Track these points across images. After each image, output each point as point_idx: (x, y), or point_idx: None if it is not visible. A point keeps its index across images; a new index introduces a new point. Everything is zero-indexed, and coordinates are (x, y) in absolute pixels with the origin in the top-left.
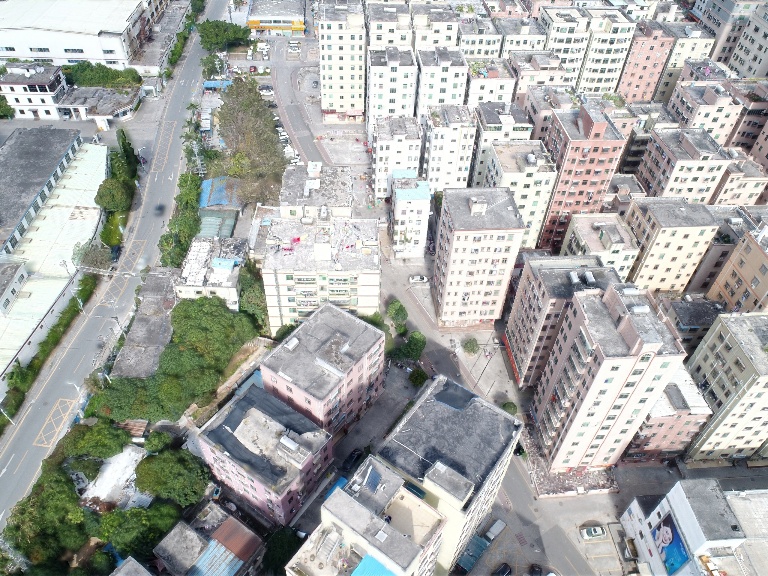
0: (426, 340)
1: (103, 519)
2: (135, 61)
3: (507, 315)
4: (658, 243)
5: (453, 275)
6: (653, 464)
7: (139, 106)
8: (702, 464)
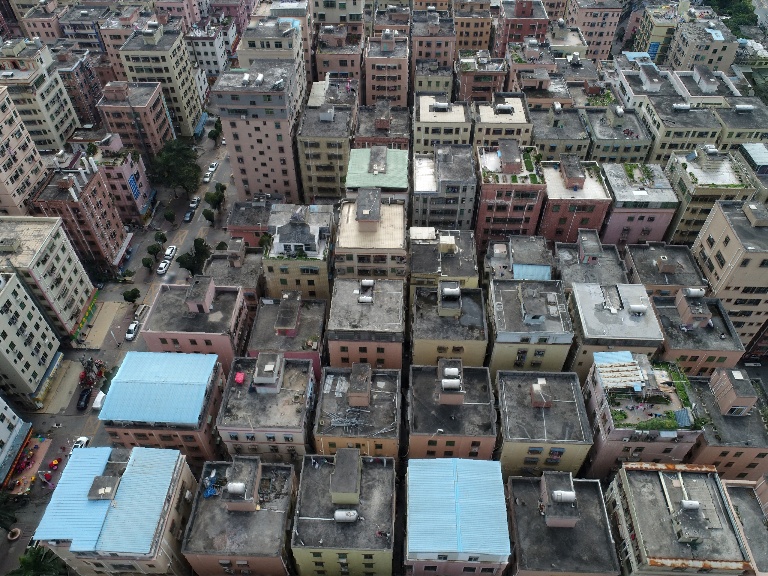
0: None
1: (718, 8)
2: None
3: None
4: None
5: None
6: None
7: None
8: None
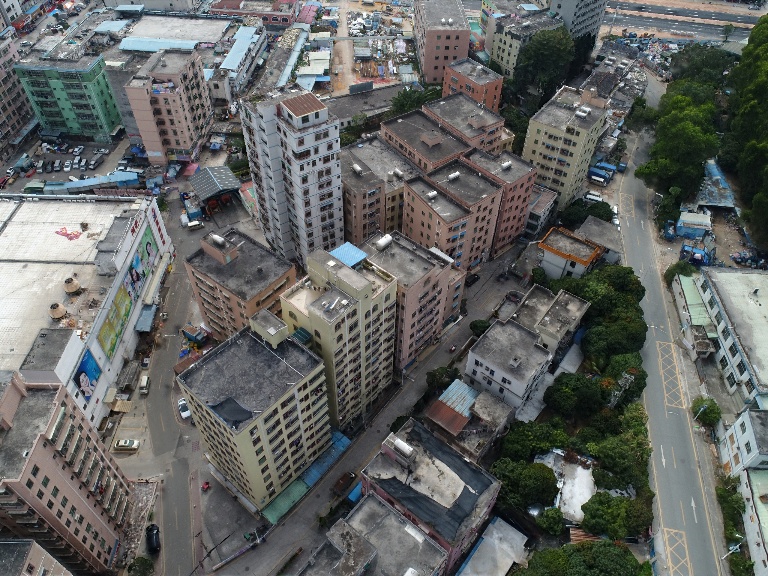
0: None
1: None
2: None
3: None
4: None
5: None
6: None
7: None
8: None
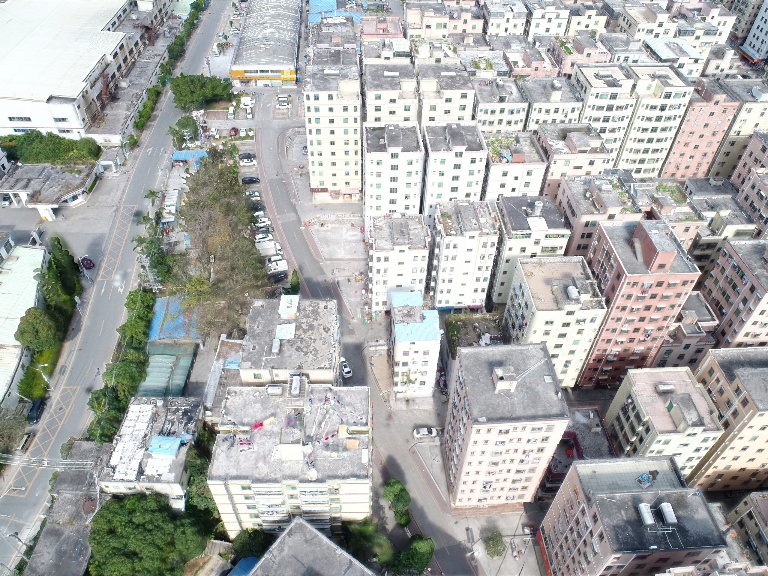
0: (435, 533)
1: None
2: (93, 128)
3: (540, 491)
4: (751, 426)
5: (470, 466)
6: None
7: (95, 185)
8: None
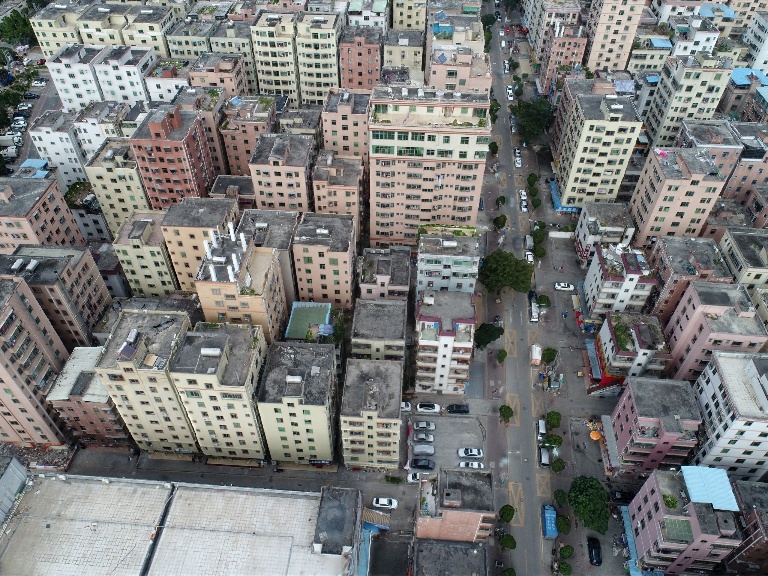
0: None
1: None
2: None
3: None
4: (169, 241)
5: None
6: (121, 450)
7: None
8: (164, 456)
